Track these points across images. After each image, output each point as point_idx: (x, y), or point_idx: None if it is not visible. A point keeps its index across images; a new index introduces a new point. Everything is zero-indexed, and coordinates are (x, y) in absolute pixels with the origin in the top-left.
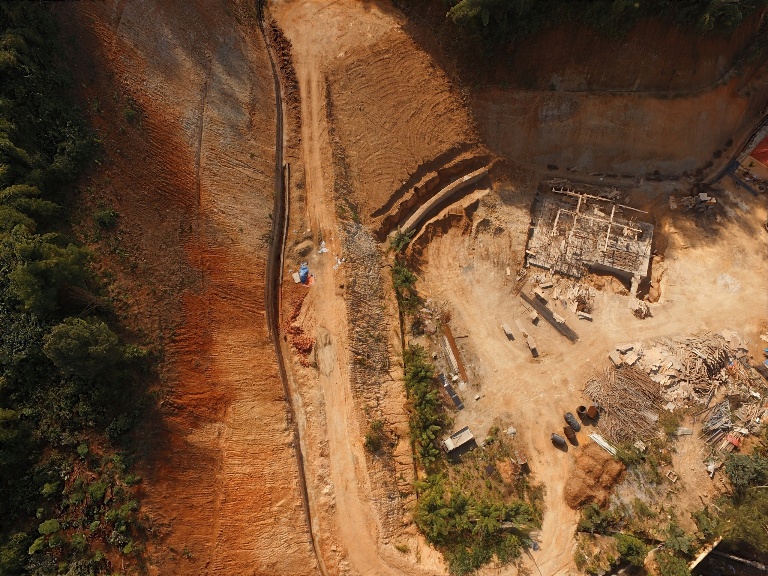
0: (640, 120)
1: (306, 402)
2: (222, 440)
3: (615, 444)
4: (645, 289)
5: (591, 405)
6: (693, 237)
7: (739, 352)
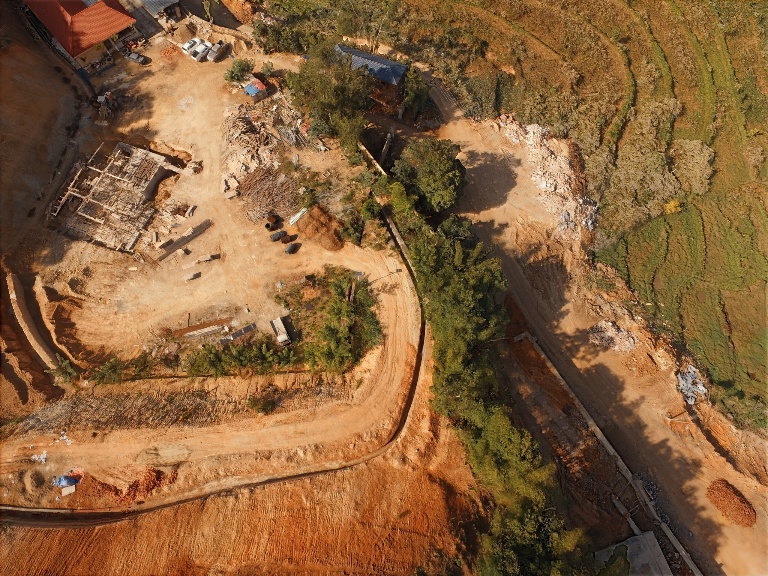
0: (1, 126)
1: (214, 476)
2: (228, 568)
3: (299, 208)
4: (178, 162)
5: (267, 220)
6: (140, 116)
7: (242, 110)
